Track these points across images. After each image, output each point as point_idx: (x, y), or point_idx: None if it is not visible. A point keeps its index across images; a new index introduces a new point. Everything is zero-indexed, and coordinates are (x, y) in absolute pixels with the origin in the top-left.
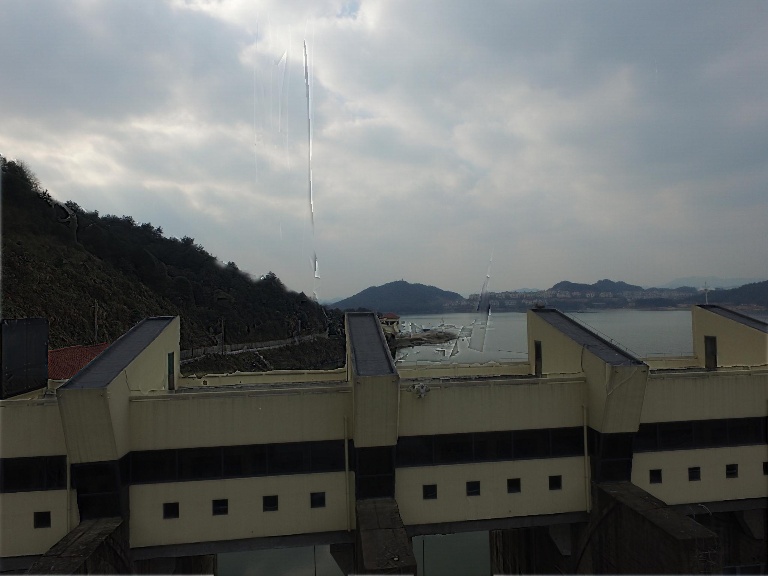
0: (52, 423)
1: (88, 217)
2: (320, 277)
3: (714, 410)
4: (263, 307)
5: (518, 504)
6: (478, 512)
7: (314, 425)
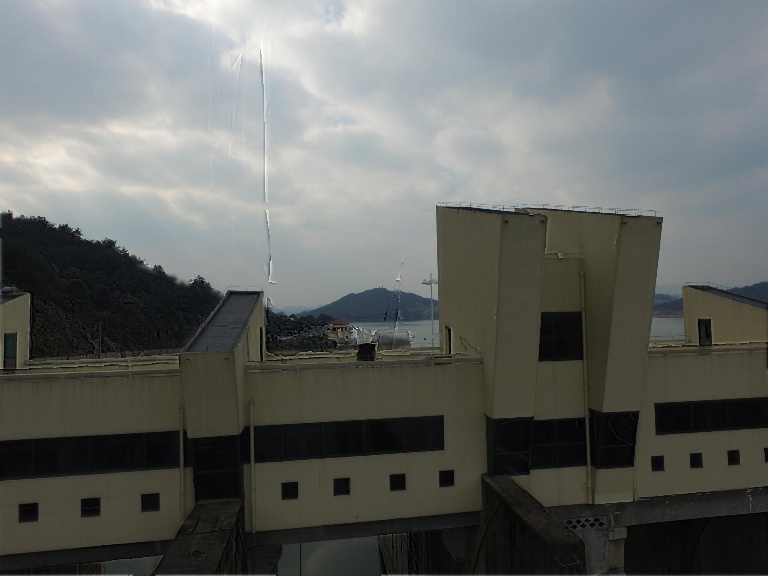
0: None
1: None
2: (276, 283)
3: (67, 425)
4: (181, 312)
5: None
6: None
7: None
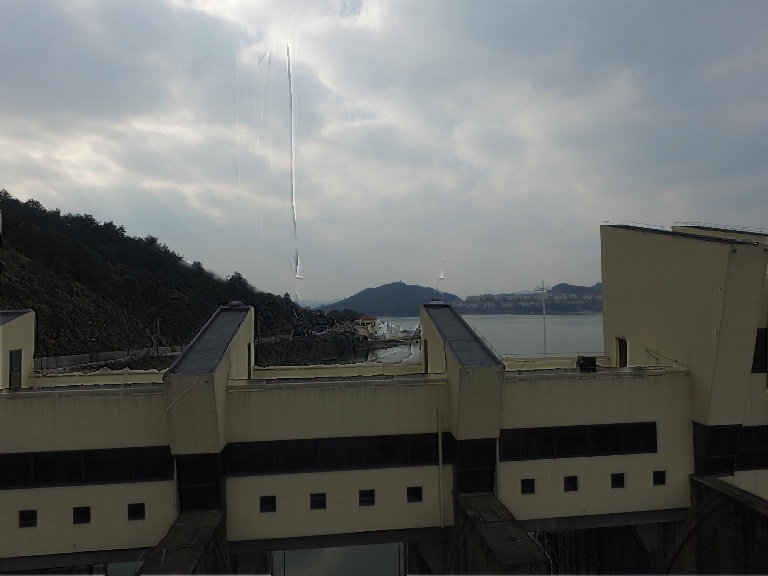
0: None
1: (48, 215)
2: (302, 278)
3: (346, 426)
4: None
5: (87, 537)
6: (34, 546)
7: None
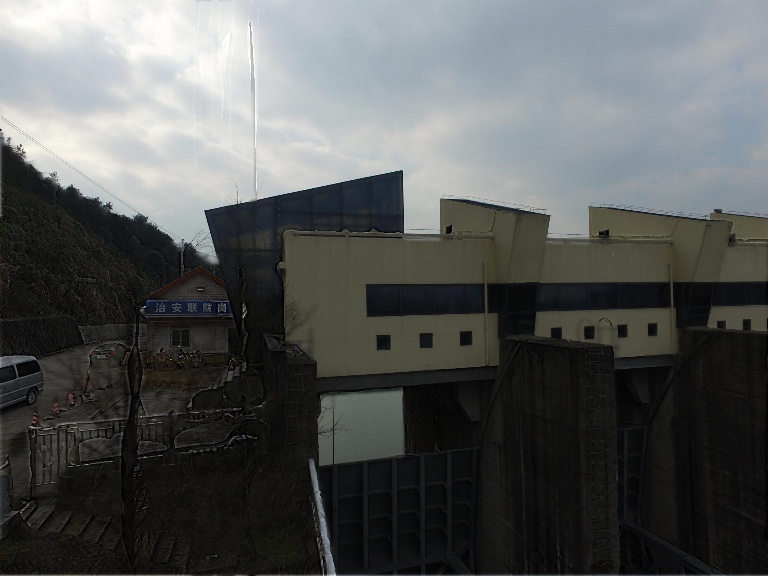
0: (470, 256)
1: None
2: None
3: None
4: None
5: None
6: None
7: (648, 269)
